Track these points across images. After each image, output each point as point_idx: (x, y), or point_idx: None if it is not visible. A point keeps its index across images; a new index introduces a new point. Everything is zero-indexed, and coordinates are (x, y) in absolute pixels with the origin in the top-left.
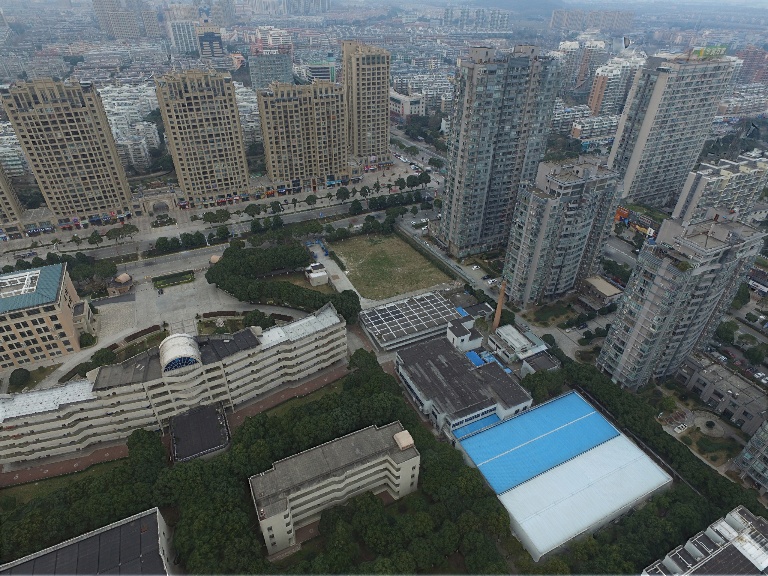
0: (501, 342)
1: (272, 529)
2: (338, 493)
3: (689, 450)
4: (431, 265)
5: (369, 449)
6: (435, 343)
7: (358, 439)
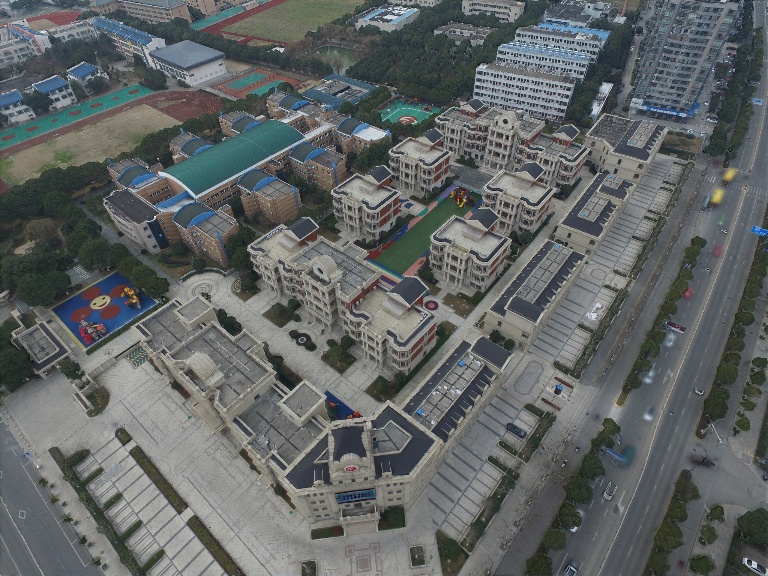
0: (612, 21)
1: (465, 9)
2: (489, 14)
3: (626, 53)
4: (637, 5)
5: (507, 3)
6: (577, 7)
7: (507, 1)
